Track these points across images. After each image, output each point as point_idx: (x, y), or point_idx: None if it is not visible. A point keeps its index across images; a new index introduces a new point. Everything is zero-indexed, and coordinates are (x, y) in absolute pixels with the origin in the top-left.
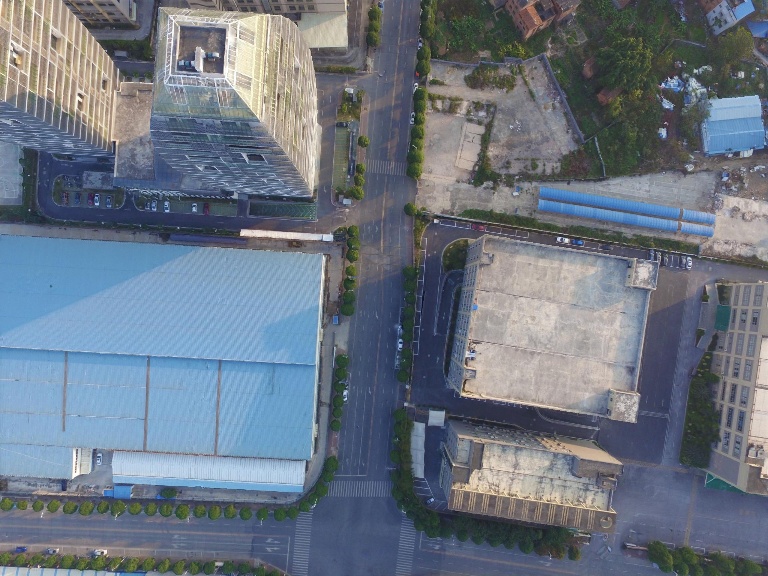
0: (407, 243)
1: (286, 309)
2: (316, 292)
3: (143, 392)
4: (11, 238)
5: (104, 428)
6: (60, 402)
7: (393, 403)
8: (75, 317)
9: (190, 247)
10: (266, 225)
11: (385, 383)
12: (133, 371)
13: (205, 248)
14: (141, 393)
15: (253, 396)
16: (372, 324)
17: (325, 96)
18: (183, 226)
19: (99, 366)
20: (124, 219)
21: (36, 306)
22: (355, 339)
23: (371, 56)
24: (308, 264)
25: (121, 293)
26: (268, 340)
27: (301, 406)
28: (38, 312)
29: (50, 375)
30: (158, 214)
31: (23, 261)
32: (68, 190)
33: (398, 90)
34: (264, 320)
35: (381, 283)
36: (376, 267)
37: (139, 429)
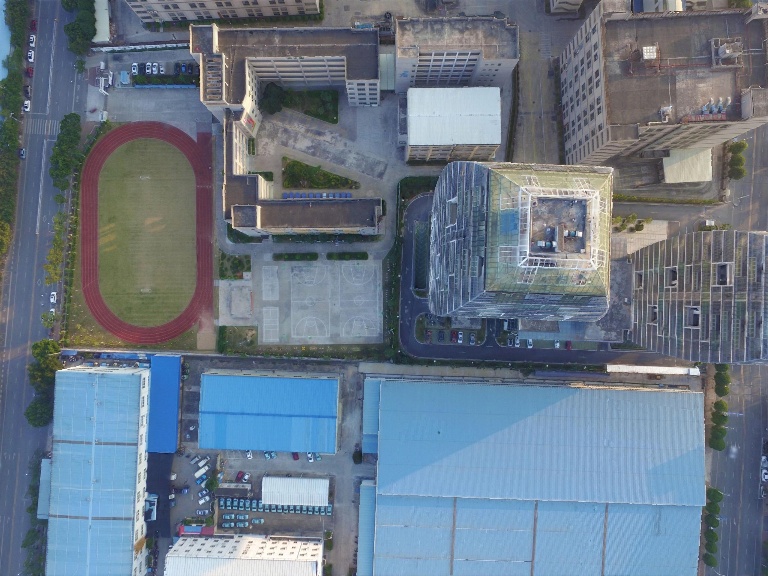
0: (767, 373)
1: (672, 450)
2: (700, 432)
3: (530, 535)
4: (395, 384)
5: (491, 571)
6: (448, 547)
7: (758, 534)
8: (465, 463)
9: (572, 389)
10: (627, 358)
11: (749, 514)
12: (521, 515)
13: (587, 390)
14: (528, 536)
15: (639, 537)
16: (735, 455)
17: (681, 227)
18: (545, 361)
19: (487, 511)
20: (486, 356)
21: (426, 453)
22: (718, 470)
23: (727, 186)
24: (690, 404)
25: (508, 438)
26: (657, 482)
27: (686, 546)
28: (428, 459)
29: (439, 520)
30: (519, 350)
31: (409, 407)
32: (431, 328)
33: (754, 219)
34: (651, 462)
35: (743, 414)
36: (737, 398)
37: (526, 572)
